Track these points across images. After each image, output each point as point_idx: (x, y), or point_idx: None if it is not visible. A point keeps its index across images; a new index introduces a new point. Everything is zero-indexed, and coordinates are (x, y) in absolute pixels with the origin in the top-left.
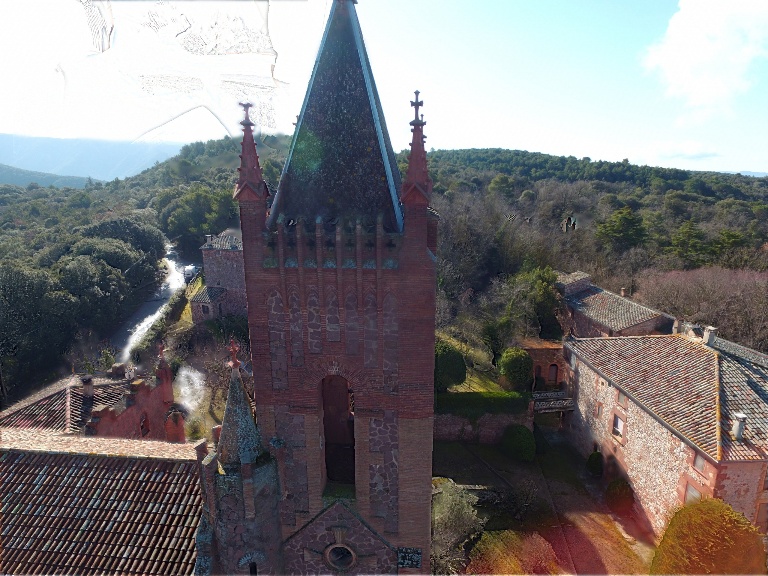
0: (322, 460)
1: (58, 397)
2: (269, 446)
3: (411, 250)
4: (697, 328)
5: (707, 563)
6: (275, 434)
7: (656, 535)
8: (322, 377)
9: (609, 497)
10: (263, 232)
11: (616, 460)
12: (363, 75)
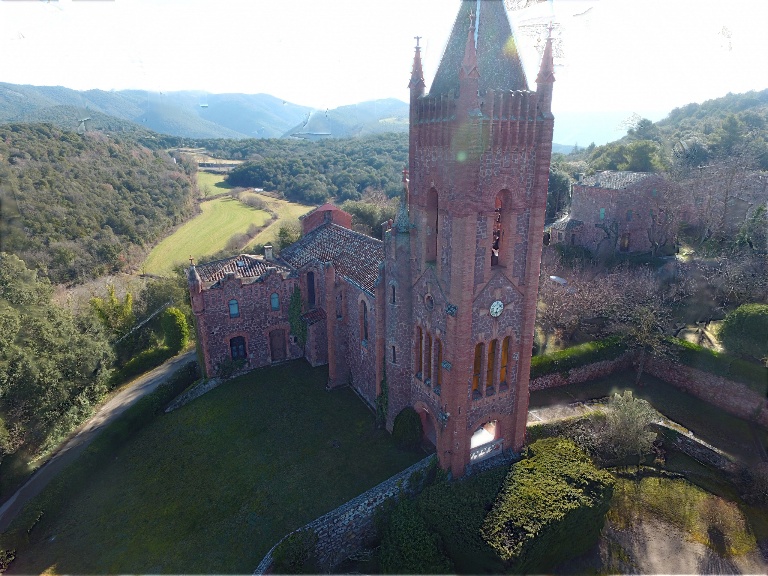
0: (430, 242)
1: None
2: None
3: (461, 108)
4: None
5: None
6: (413, 222)
7: None
8: (429, 189)
9: None
10: (416, 105)
11: None
12: (477, 5)
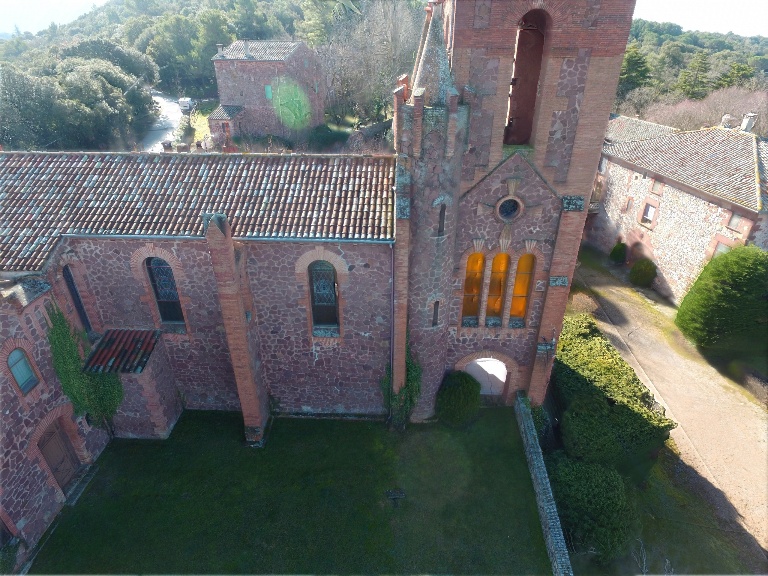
0: None
1: None
2: (464, 92)
3: None
4: (727, 127)
5: (738, 290)
6: (468, 82)
7: (676, 297)
8: (525, 12)
9: (634, 274)
10: None
11: (641, 245)
12: None
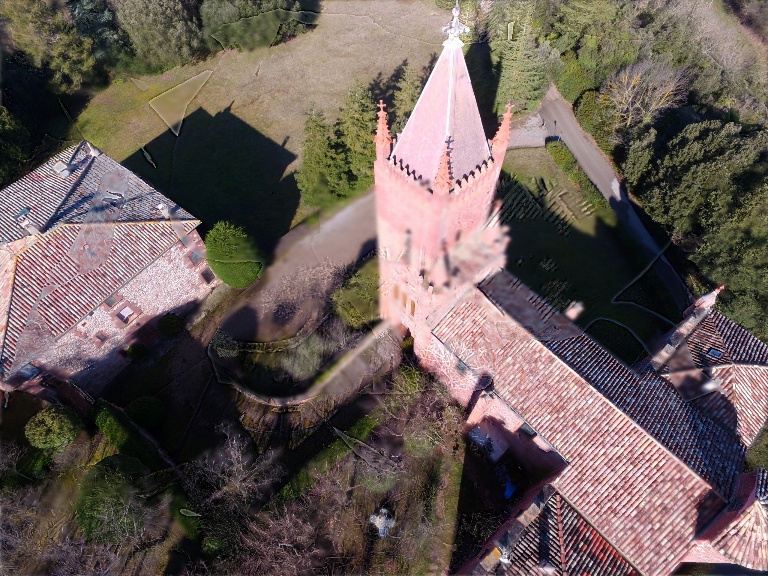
0: None
1: (574, 574)
2: None
3: None
4: None
5: None
6: None
7: (196, 299)
8: None
9: None
10: None
11: None
12: None
